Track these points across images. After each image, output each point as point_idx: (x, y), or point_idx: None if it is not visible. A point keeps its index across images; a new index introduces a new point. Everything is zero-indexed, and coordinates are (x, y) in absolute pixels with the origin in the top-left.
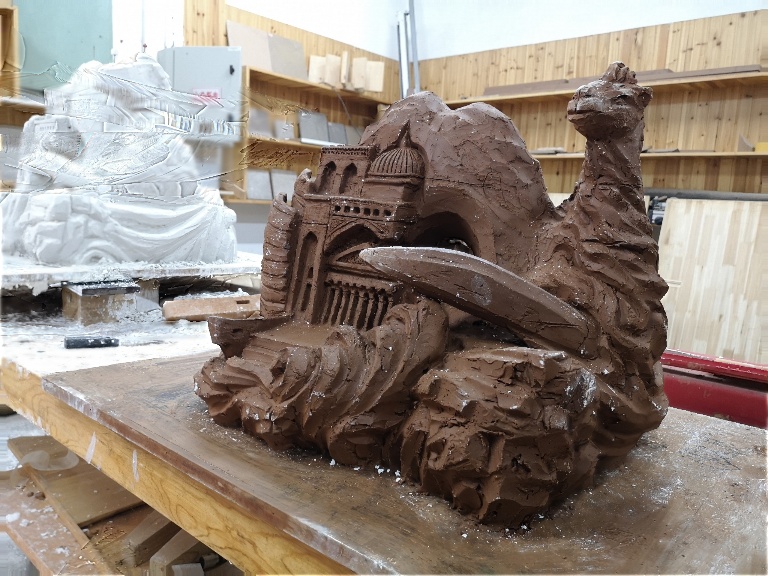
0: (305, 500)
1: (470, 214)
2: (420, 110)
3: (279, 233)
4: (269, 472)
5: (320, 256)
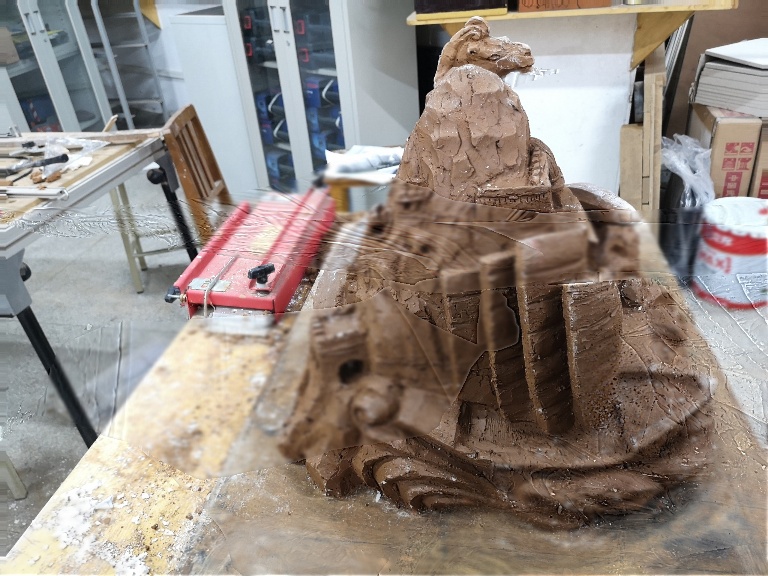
0: None
1: None
2: None
3: None
4: None
5: None
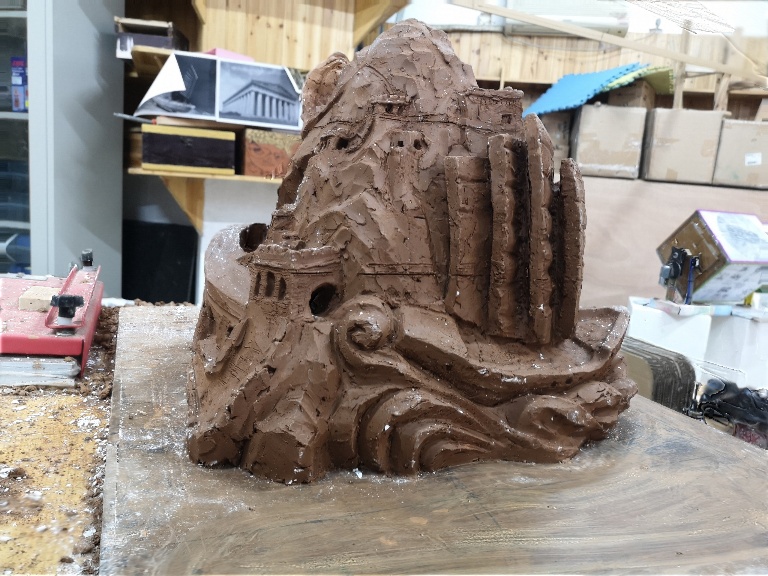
0: None
1: None
2: None
3: None
4: None
5: None
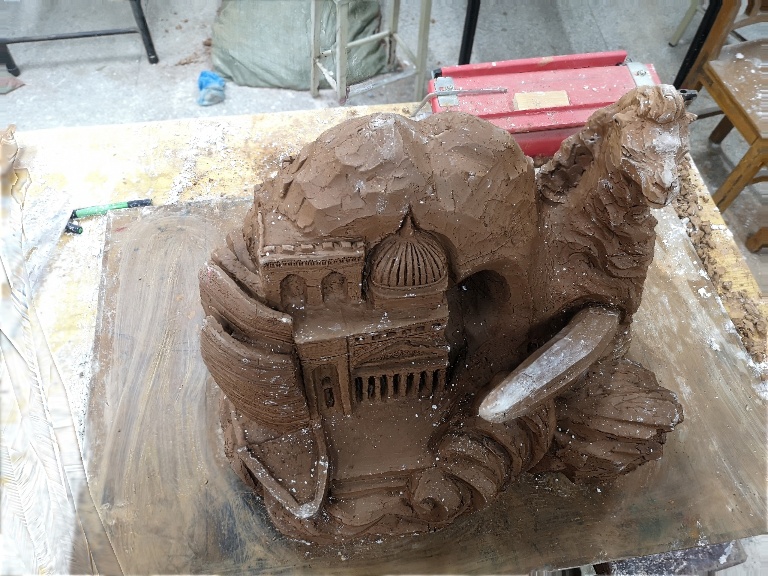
0: (509, 554)
1: (499, 266)
2: (417, 184)
3: (284, 389)
4: (455, 552)
5: (347, 377)
